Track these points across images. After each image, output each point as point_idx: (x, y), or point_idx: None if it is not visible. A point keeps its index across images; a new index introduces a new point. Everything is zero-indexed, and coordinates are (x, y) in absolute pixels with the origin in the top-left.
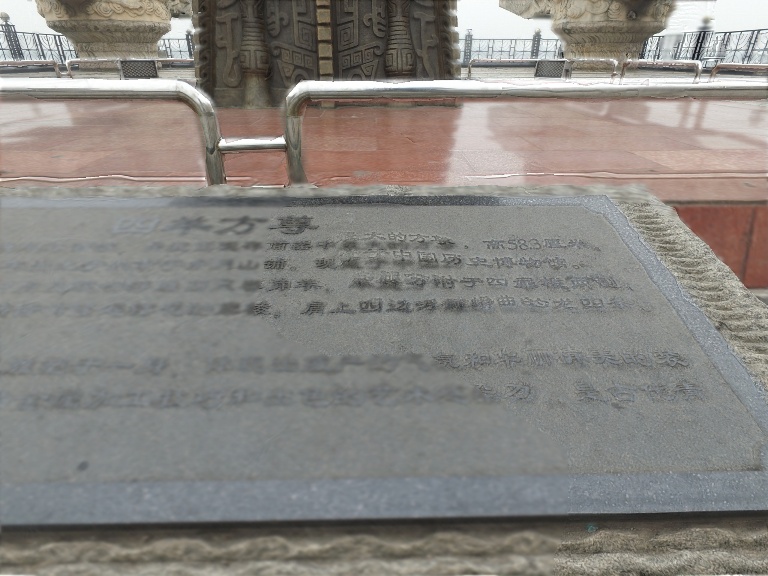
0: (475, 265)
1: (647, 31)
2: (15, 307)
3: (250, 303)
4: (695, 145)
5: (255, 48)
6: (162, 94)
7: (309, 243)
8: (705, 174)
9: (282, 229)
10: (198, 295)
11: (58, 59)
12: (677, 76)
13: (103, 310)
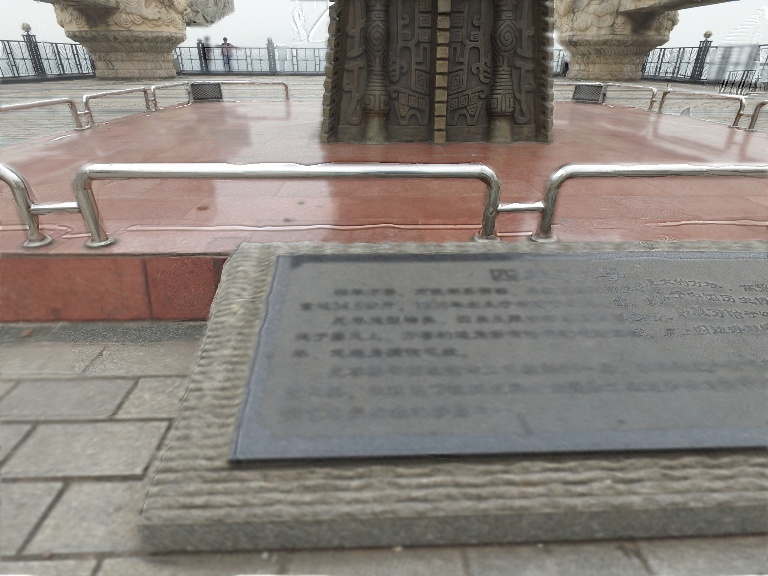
0: (745, 303)
1: (650, 44)
2: (492, 332)
3: (628, 329)
4: None
5: (380, 93)
6: (468, 174)
7: (629, 287)
8: None
9: (606, 278)
10: (592, 324)
11: (75, 68)
12: (683, 89)
13: (545, 334)
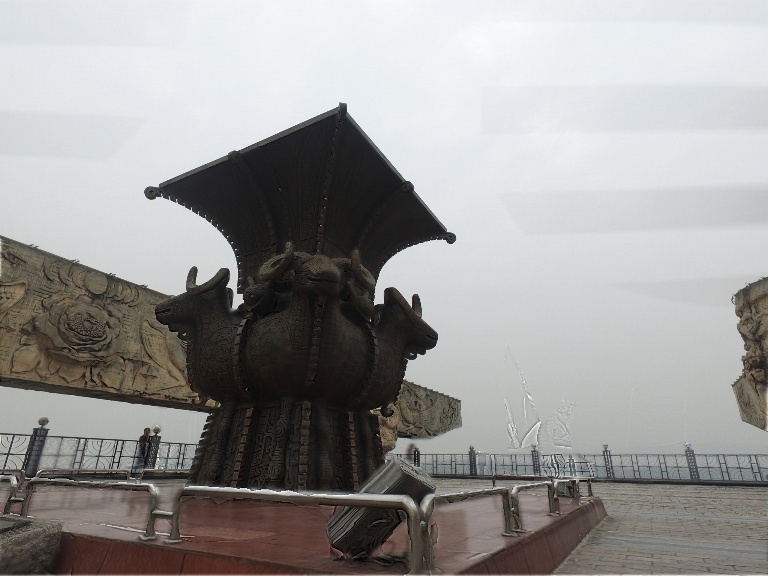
0: None
1: None
2: None
3: None
4: None
5: (212, 464)
6: (8, 480)
7: None
8: None
9: None
10: None
11: None
12: None
13: None
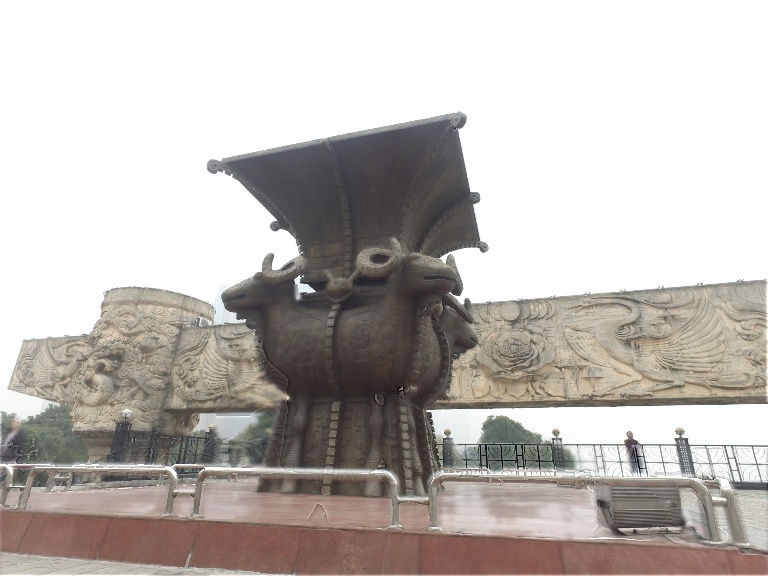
0: None
1: None
2: None
3: None
4: None
5: None
6: None
7: None
8: None
9: None
10: None
11: None
12: None
13: None
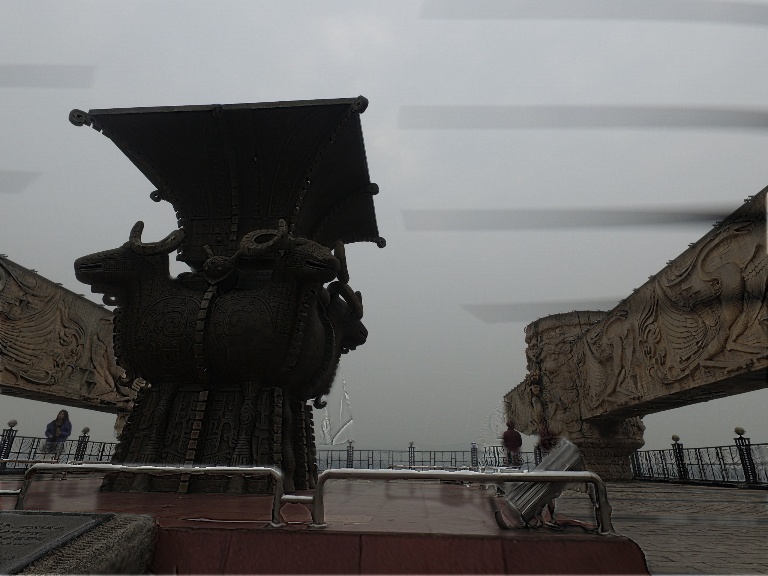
0: (2, 532)
1: (625, 446)
2: None
3: None
4: (328, 513)
5: (149, 453)
6: None
7: None
8: (260, 521)
9: None
10: None
11: None
12: None
13: None
